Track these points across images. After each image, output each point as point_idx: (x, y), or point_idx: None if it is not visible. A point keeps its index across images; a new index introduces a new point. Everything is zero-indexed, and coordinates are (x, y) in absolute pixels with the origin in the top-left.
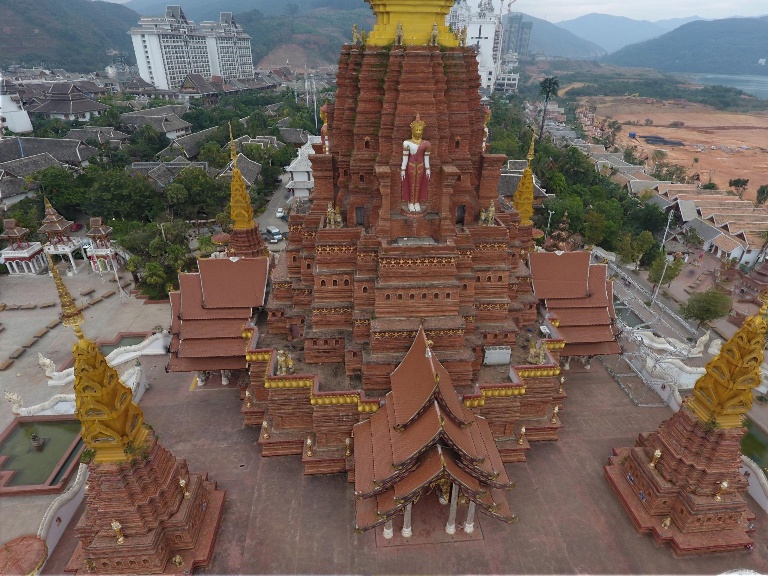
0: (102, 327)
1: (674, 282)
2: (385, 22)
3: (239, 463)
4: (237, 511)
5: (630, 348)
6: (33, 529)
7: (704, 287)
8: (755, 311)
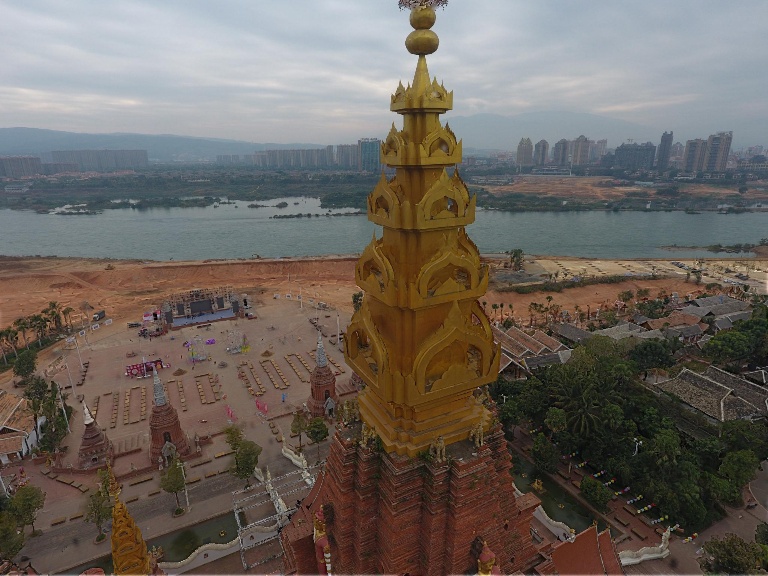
0: None
1: (67, 503)
2: (466, 398)
3: None
4: None
5: None
6: None
7: (87, 482)
8: (132, 459)
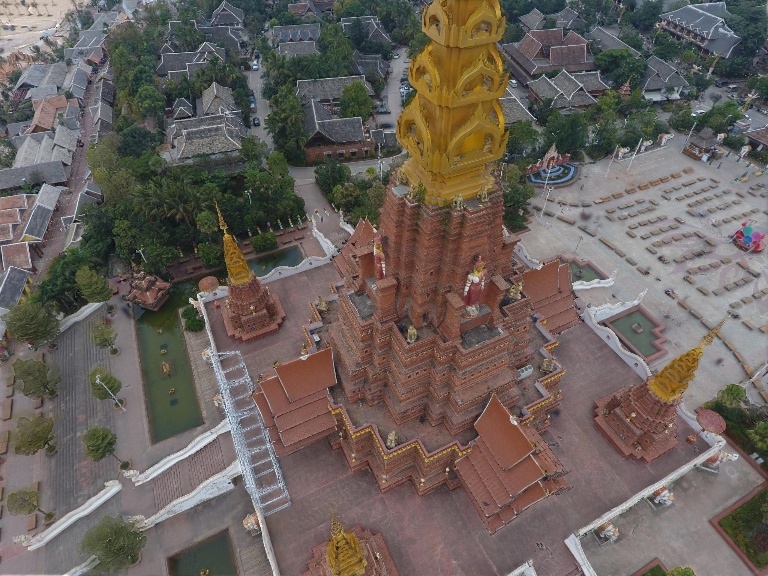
0: None
1: None
2: None
3: None
4: None
5: (231, 451)
6: None
7: None
8: None
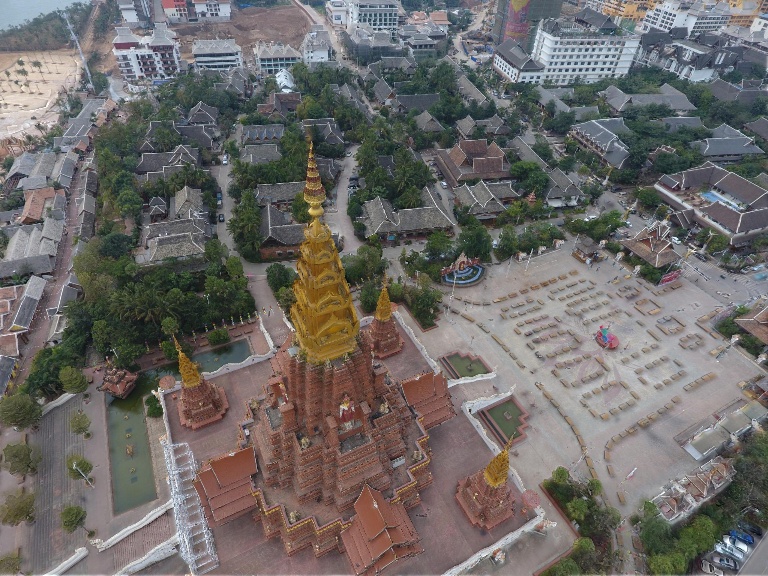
0: (548, 441)
1: None
2: None
3: None
4: None
5: None
6: (433, 348)
7: None
8: None
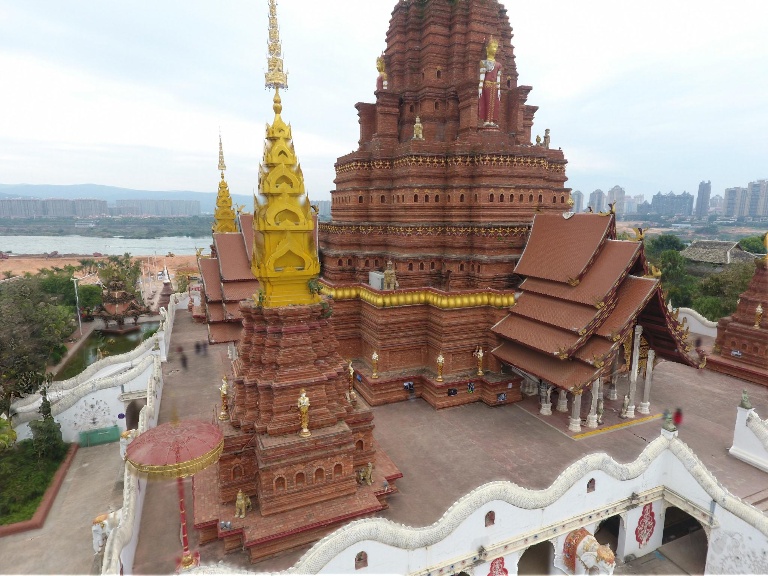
0: None
1: None
2: None
3: (667, 363)
4: (692, 354)
5: None
6: None
7: None
8: None
